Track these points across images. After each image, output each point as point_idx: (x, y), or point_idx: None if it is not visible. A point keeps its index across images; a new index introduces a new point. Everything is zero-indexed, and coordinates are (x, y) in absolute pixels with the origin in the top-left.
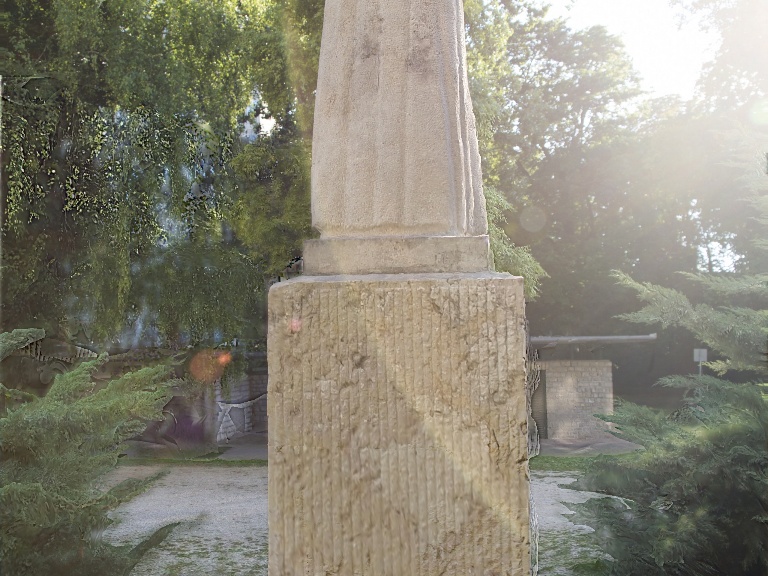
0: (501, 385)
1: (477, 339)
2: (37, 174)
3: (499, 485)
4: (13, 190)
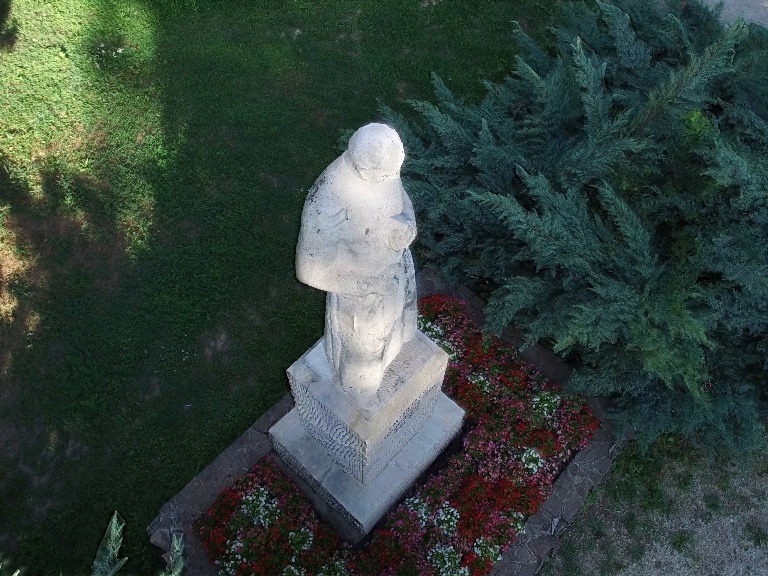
0: None
1: None
2: None
3: None
4: None
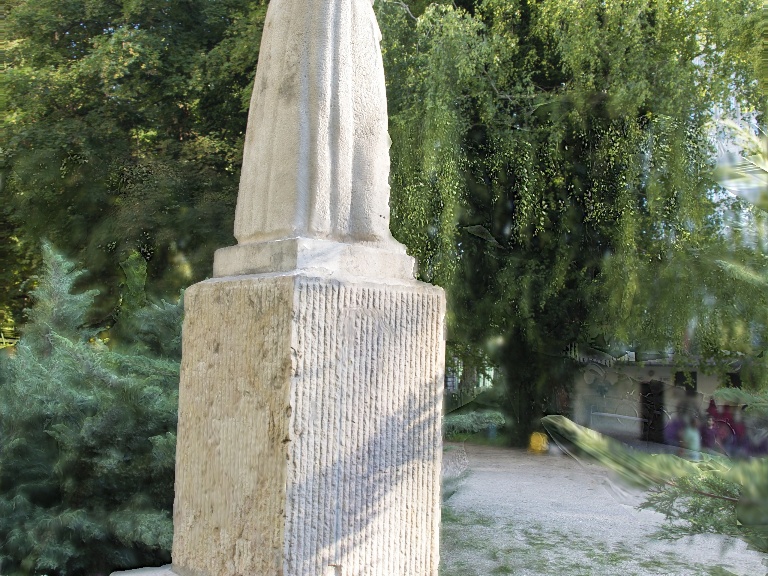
0: (277, 372)
1: (268, 330)
2: (559, 190)
3: (272, 461)
4: (518, 208)
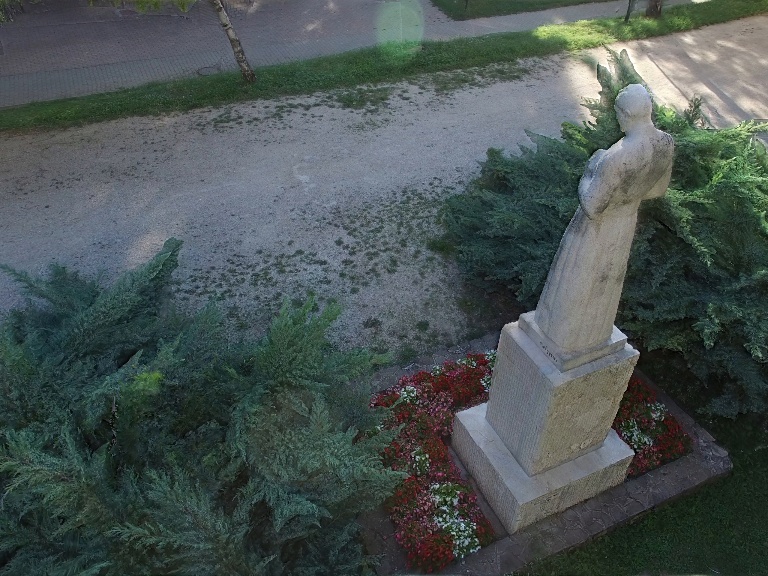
0: None
1: None
2: None
3: None
4: None
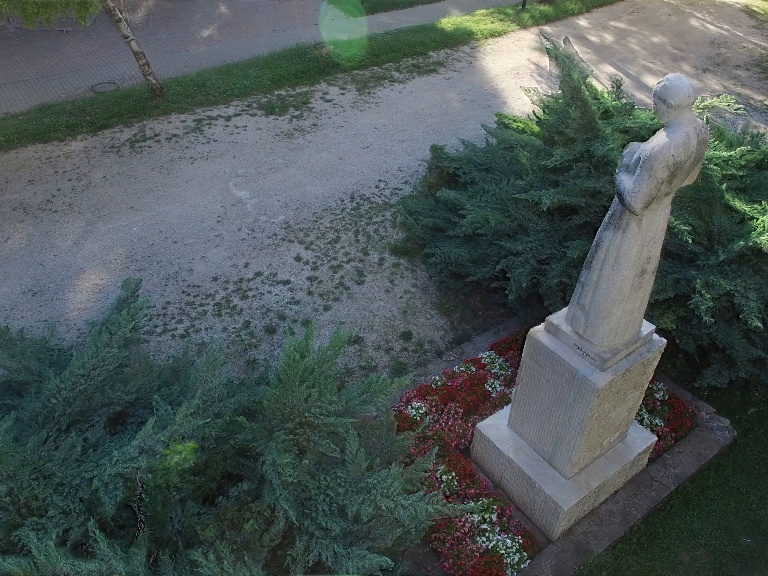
0: None
1: None
2: None
3: None
4: None
